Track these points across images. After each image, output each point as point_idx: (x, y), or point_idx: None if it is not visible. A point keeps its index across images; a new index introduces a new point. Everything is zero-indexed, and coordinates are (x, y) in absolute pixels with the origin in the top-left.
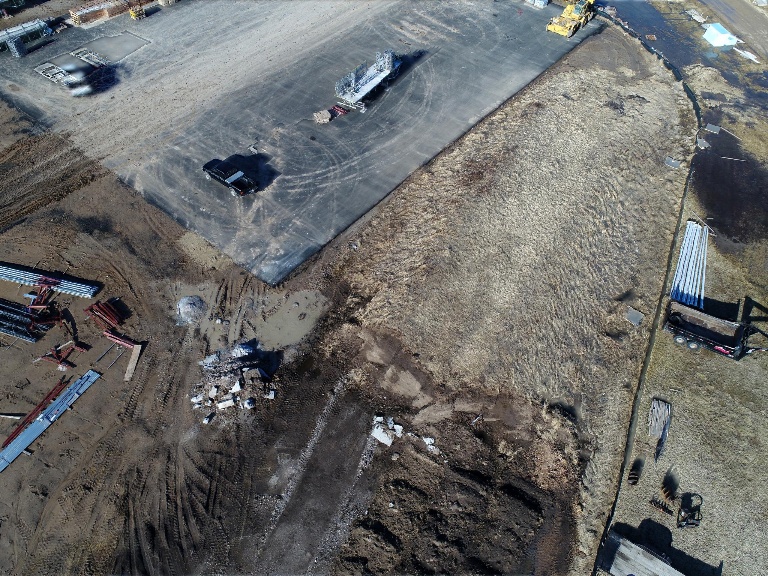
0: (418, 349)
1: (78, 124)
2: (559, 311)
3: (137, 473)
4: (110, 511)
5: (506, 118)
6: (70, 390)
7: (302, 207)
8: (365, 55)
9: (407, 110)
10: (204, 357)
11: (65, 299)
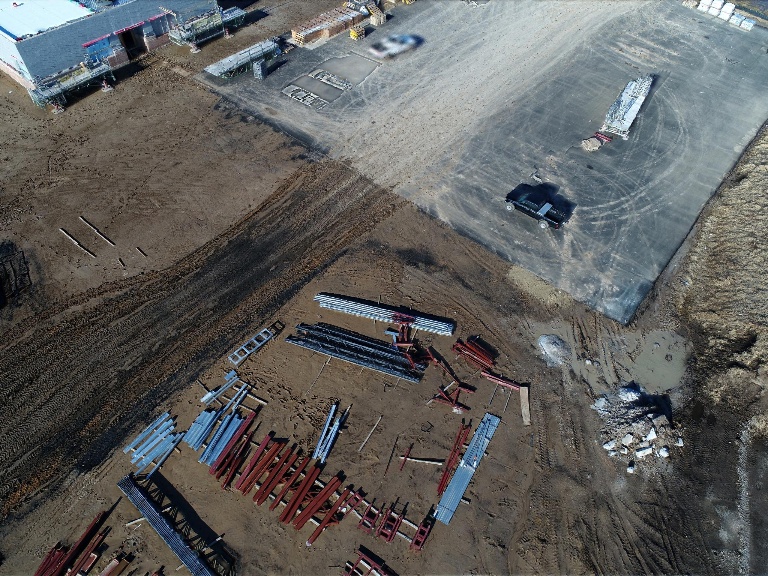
0: None
1: (353, 150)
2: None
3: (586, 525)
4: (577, 566)
5: None
6: (479, 435)
7: (614, 240)
8: (600, 79)
9: (668, 138)
10: (593, 400)
11: (425, 336)
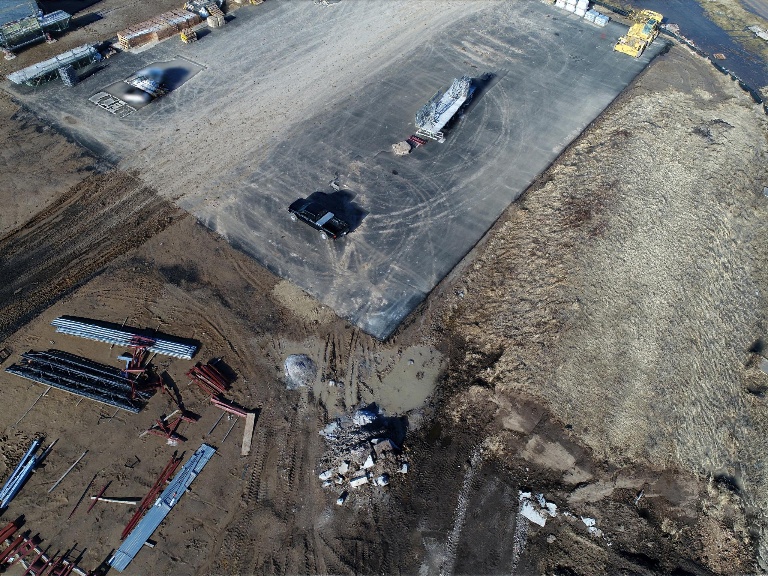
0: (570, 419)
1: (145, 160)
2: (704, 369)
3: (274, 566)
4: None
5: (592, 147)
6: (186, 469)
7: (398, 250)
8: (432, 79)
9: (487, 139)
10: (324, 426)
11: (162, 361)
